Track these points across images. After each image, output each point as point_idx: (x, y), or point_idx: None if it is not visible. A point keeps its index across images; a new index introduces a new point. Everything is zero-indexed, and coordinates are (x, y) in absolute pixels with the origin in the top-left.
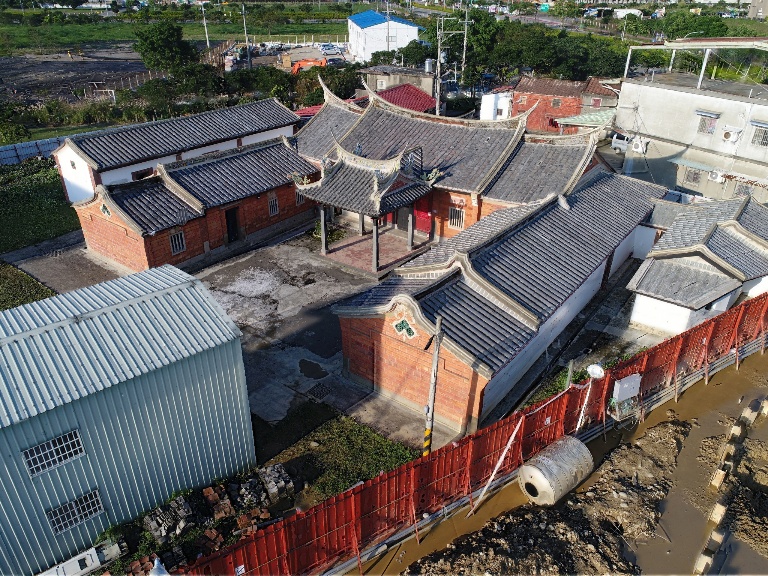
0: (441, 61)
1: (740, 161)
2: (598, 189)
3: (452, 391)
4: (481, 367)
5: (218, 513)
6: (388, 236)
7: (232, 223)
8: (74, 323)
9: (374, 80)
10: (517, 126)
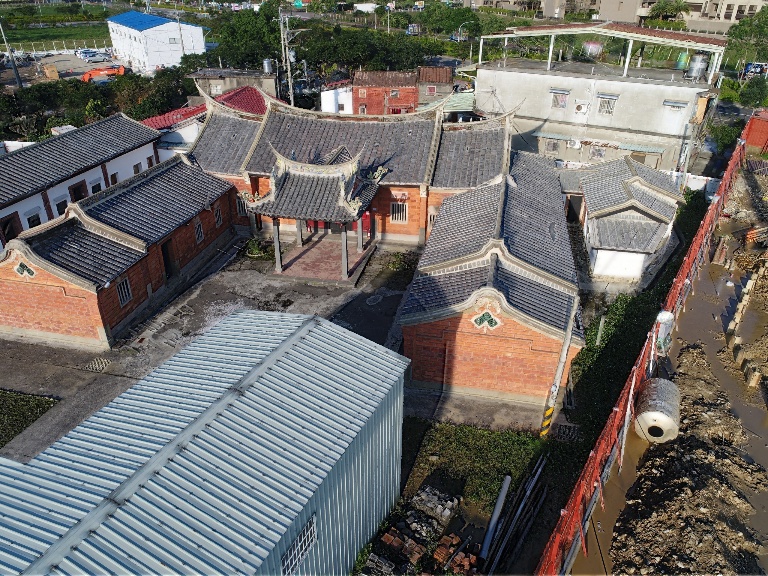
0: (291, 60)
1: (591, 128)
2: (519, 166)
3: (538, 368)
4: (574, 338)
5: (412, 556)
6: (327, 242)
7: (165, 258)
8: (239, 396)
9: (207, 85)
10: (435, 117)
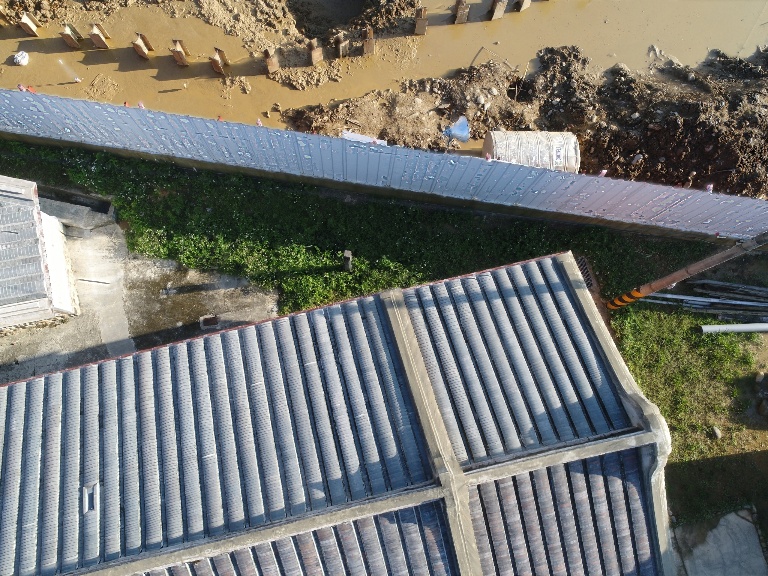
0: None
1: None
2: None
3: None
4: None
5: None
6: None
7: None
8: None
9: None
10: None
